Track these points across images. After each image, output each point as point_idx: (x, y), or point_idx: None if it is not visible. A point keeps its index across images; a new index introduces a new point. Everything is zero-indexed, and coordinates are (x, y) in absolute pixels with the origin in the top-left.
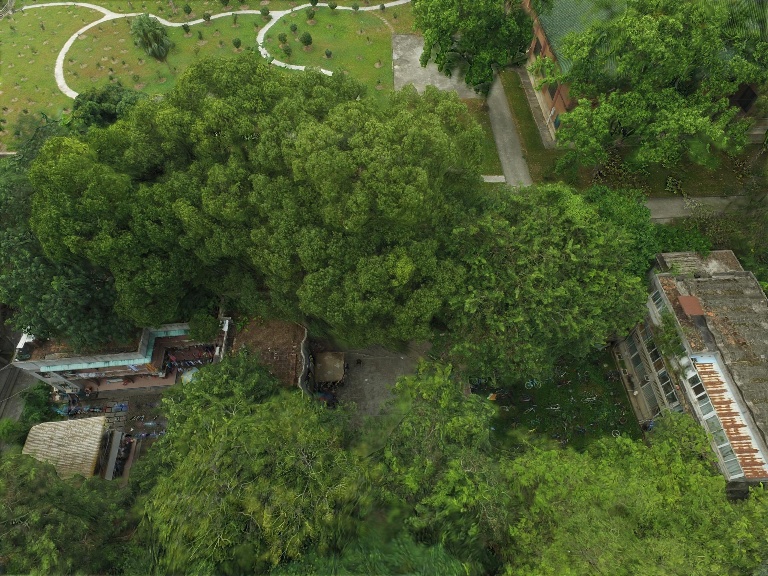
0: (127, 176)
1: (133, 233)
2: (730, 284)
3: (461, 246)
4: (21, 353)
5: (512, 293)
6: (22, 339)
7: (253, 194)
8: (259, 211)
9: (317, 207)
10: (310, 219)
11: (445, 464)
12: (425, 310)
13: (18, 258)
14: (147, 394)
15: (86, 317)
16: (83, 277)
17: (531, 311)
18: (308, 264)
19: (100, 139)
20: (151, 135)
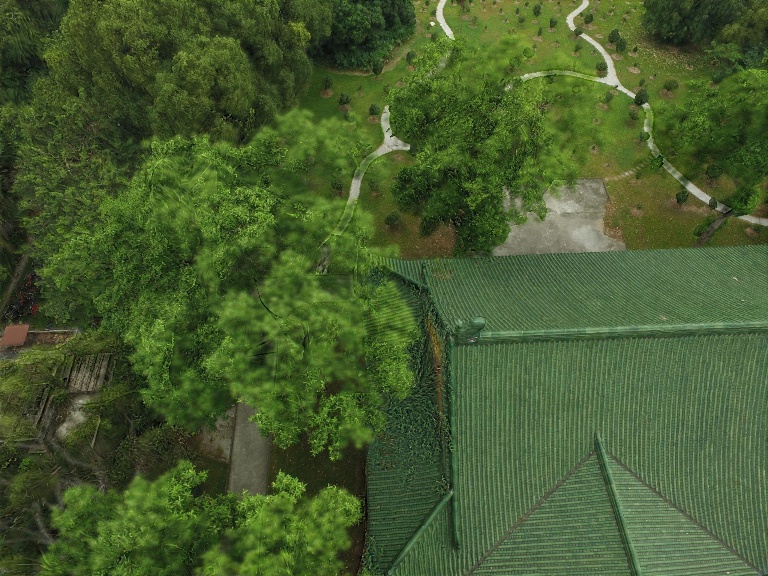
0: None
1: None
2: (29, 401)
3: None
4: None
5: None
6: None
7: None
8: None
9: None
10: None
11: None
12: None
13: None
14: None
15: None
16: None
17: None
18: None
19: None
20: None
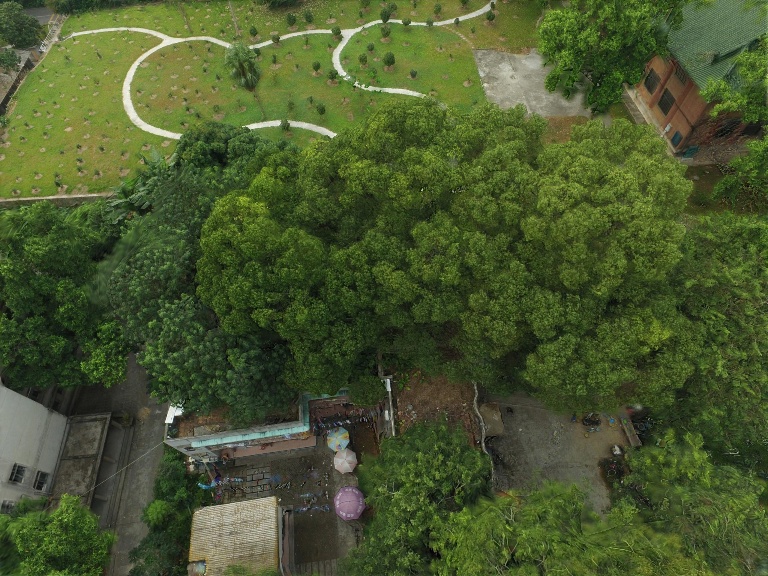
0: (312, 237)
1: (323, 300)
2: None
3: (688, 299)
4: (170, 428)
5: (746, 348)
6: (170, 412)
7: (473, 256)
8: (474, 273)
9: (537, 265)
10: (533, 279)
11: (763, 566)
12: (678, 378)
13: (189, 332)
14: (288, 458)
15: (256, 390)
16: (256, 348)
17: (766, 366)
18: (543, 332)
19: (264, 194)
20: (330, 189)
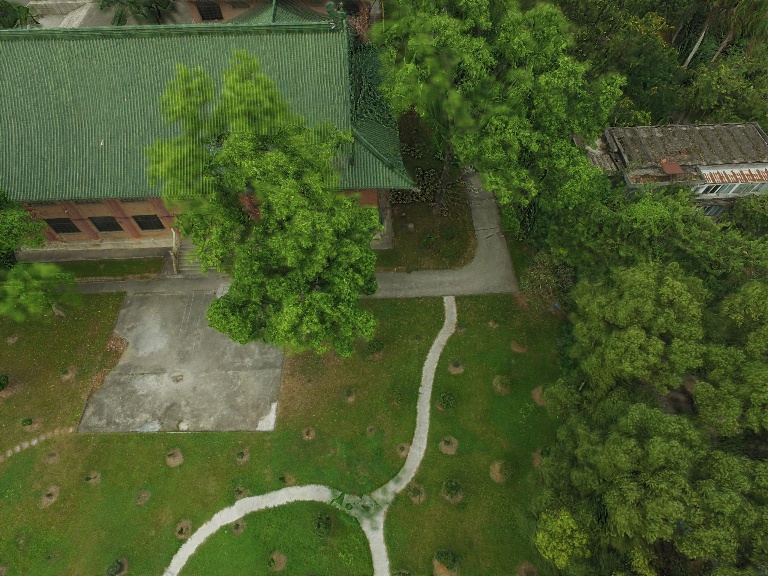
0: None
1: None
2: (628, 142)
3: None
4: None
5: None
6: None
7: None
8: None
9: None
10: None
11: None
12: None
13: None
14: None
15: None
16: None
17: None
18: None
19: None
20: None
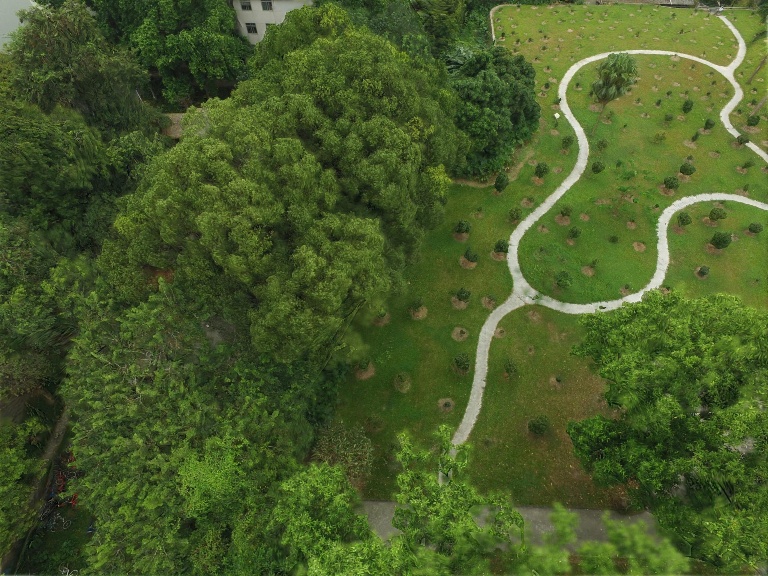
0: None
1: None
2: None
3: None
4: None
5: None
6: None
7: None
8: None
9: None
10: None
11: None
12: None
13: None
14: None
15: None
16: None
17: None
18: None
19: None
20: None
